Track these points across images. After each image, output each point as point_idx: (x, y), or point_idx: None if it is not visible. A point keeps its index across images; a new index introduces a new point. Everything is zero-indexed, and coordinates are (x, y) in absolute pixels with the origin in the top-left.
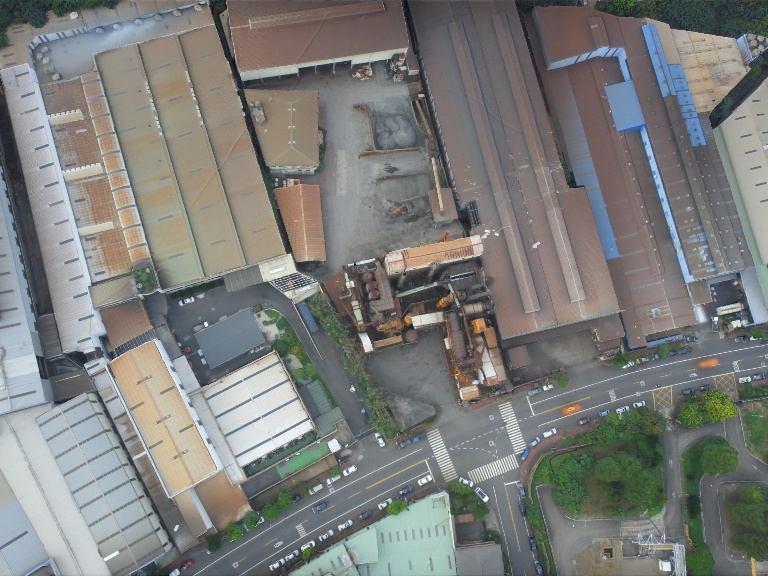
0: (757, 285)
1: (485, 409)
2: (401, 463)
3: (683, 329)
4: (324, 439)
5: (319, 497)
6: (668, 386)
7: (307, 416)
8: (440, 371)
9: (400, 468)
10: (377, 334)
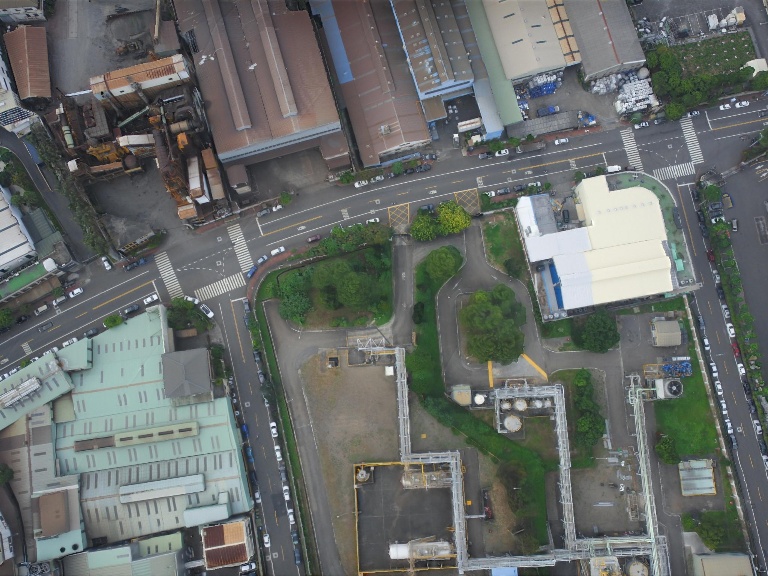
0: (490, 96)
1: (213, 231)
2: (128, 285)
3: (424, 149)
4: (43, 260)
5: (45, 318)
6: (405, 203)
7: (26, 239)
8: (169, 198)
9: (127, 289)
10: (98, 162)
